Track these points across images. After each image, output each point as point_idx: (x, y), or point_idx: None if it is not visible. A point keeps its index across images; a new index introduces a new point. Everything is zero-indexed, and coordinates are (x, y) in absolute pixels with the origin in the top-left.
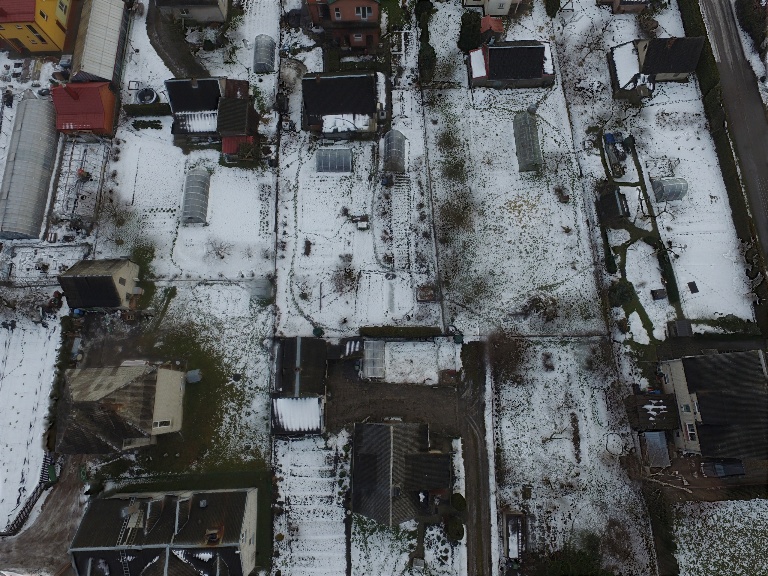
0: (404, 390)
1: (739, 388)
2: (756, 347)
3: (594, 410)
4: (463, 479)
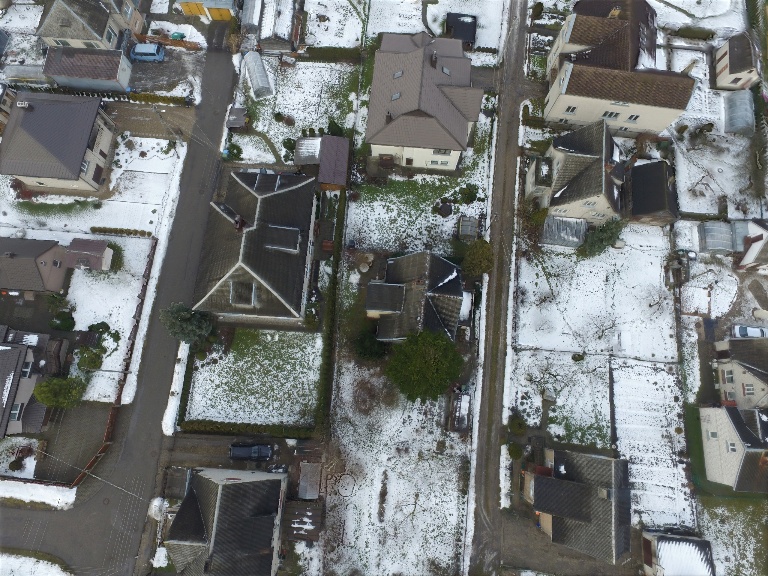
0: (558, 568)
1: (233, 560)
2: (166, 575)
3: (358, 523)
4: (502, 467)
